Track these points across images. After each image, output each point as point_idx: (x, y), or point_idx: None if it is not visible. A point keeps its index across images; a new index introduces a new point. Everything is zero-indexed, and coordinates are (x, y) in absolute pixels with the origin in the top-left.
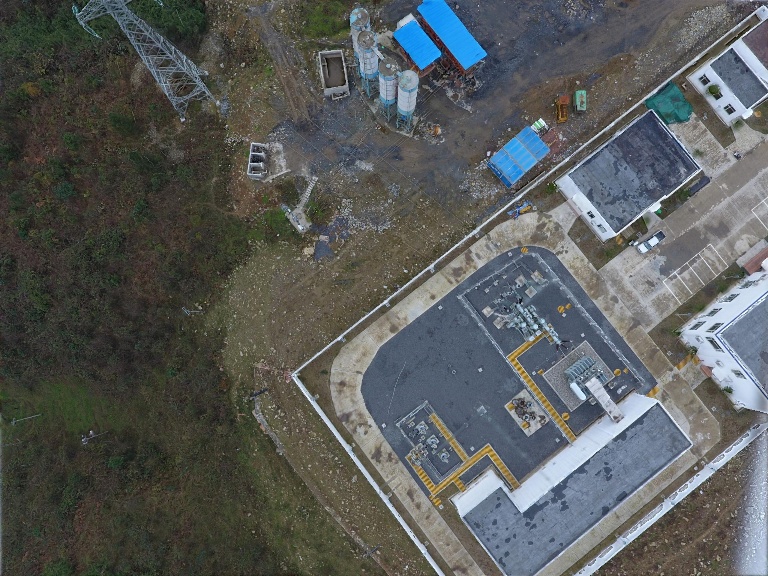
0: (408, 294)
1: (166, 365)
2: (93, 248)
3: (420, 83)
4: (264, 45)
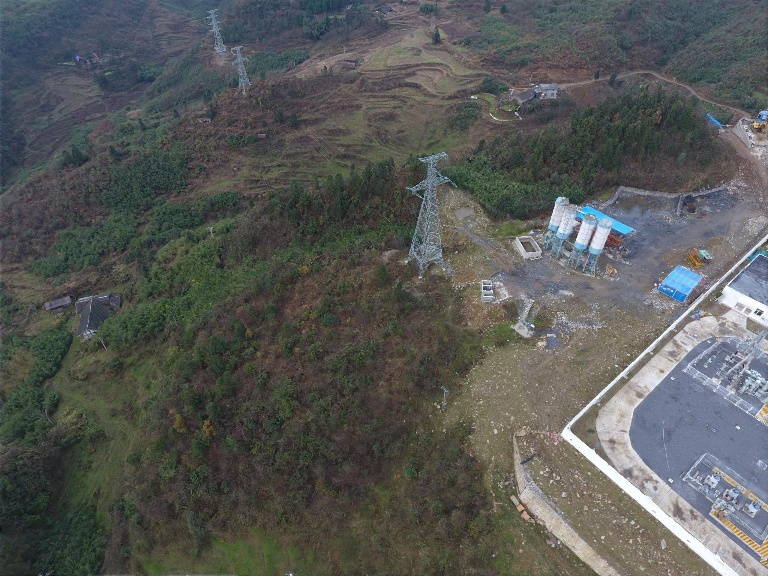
0: (639, 369)
1: (391, 480)
2: (352, 354)
3: None
4: (472, 241)
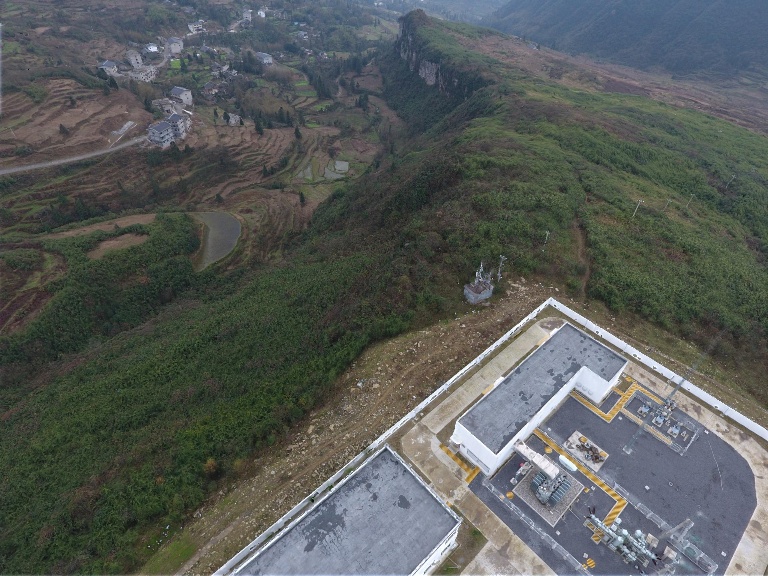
0: (767, 569)
1: None
2: None
3: None
4: None
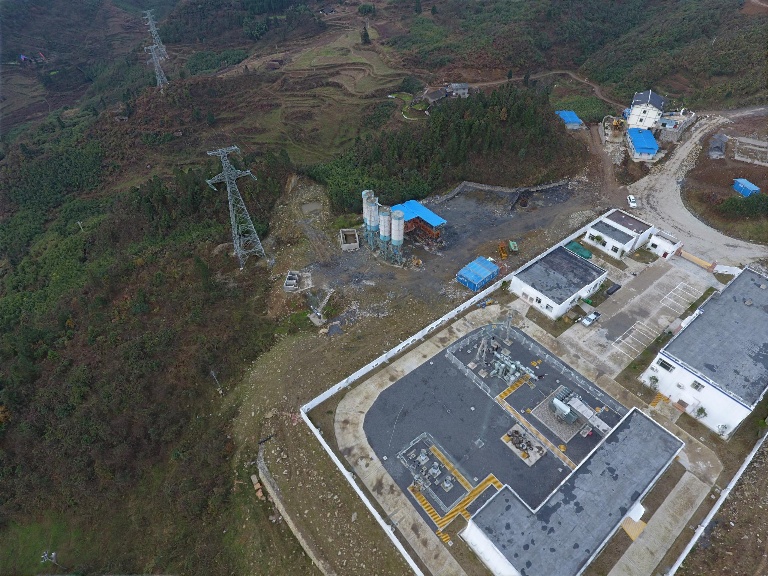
0: (404, 355)
1: (168, 462)
2: None
3: (406, 244)
4: (304, 234)
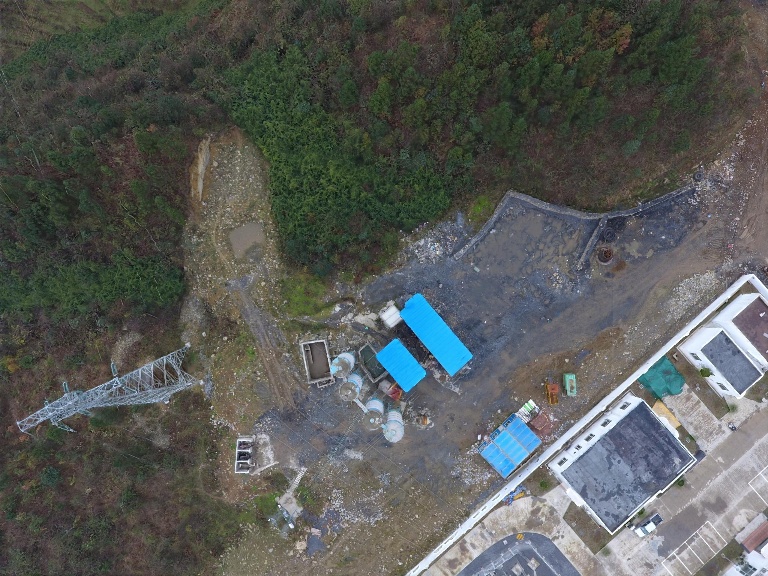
0: None
1: None
2: (82, 537)
3: None
4: (246, 323)
